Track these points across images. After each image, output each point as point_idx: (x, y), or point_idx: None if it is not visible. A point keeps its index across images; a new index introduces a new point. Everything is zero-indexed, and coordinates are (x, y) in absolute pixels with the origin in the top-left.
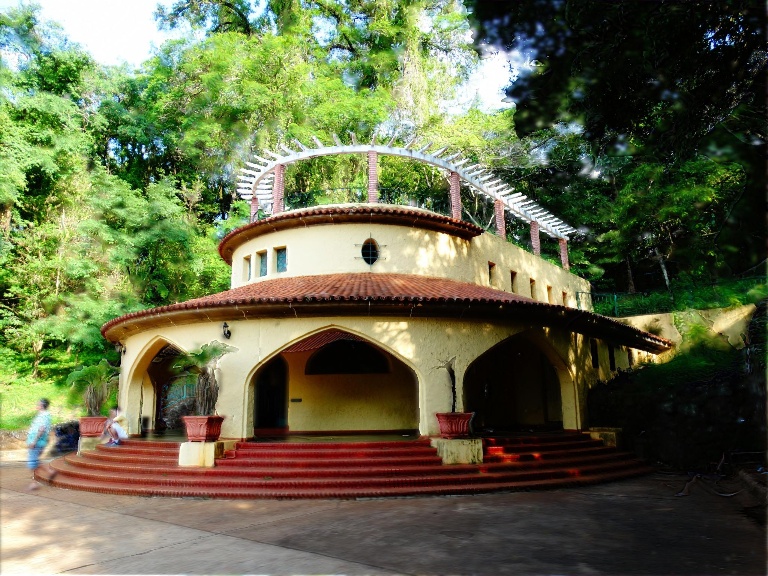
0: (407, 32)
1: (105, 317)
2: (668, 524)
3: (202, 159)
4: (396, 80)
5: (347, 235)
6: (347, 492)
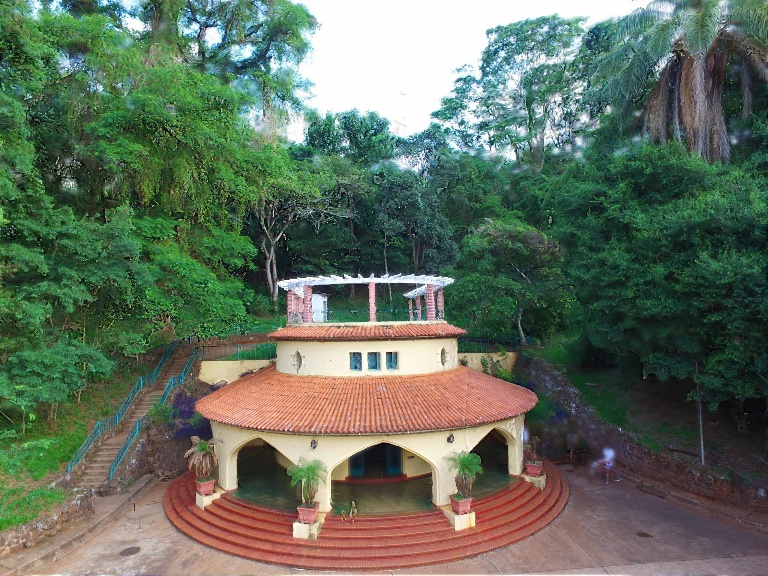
0: (282, 89)
1: (67, 367)
2: (651, 506)
3: (102, 170)
4: (248, 115)
5: (434, 347)
6: (549, 522)
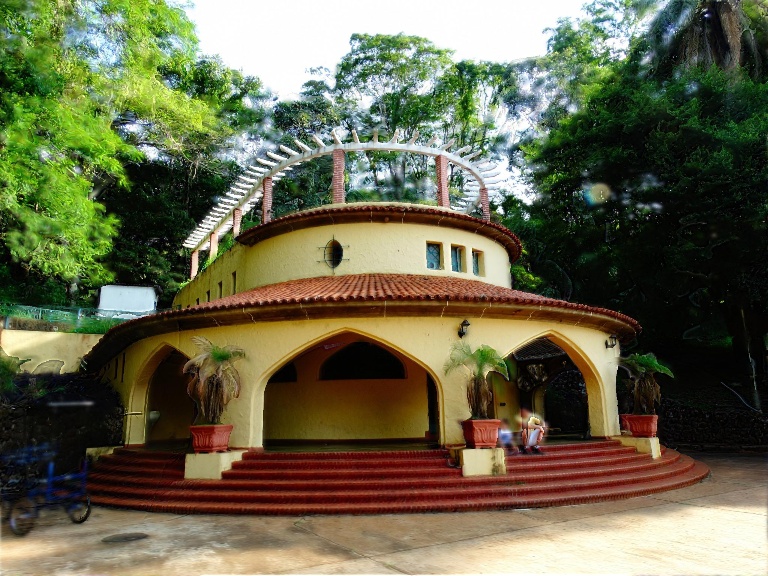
0: None
1: None
2: None
3: None
4: None
5: None
6: None
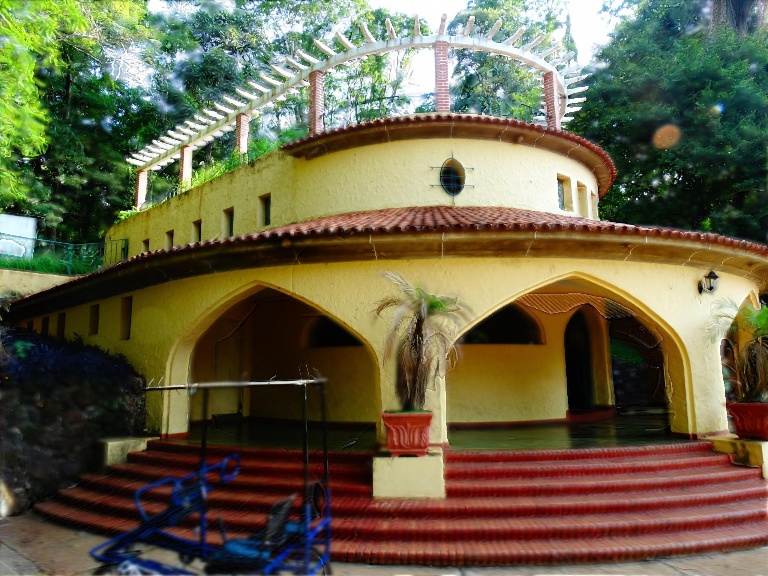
0: None
1: None
2: None
3: None
4: None
5: None
6: None
